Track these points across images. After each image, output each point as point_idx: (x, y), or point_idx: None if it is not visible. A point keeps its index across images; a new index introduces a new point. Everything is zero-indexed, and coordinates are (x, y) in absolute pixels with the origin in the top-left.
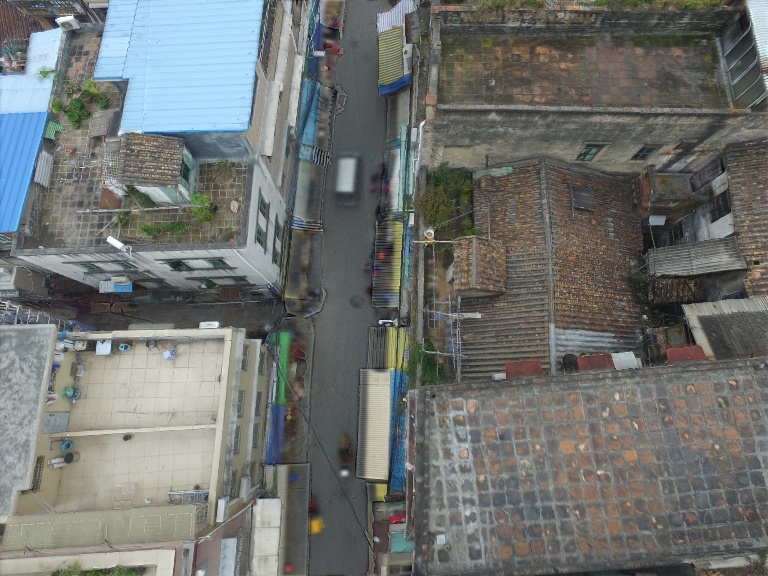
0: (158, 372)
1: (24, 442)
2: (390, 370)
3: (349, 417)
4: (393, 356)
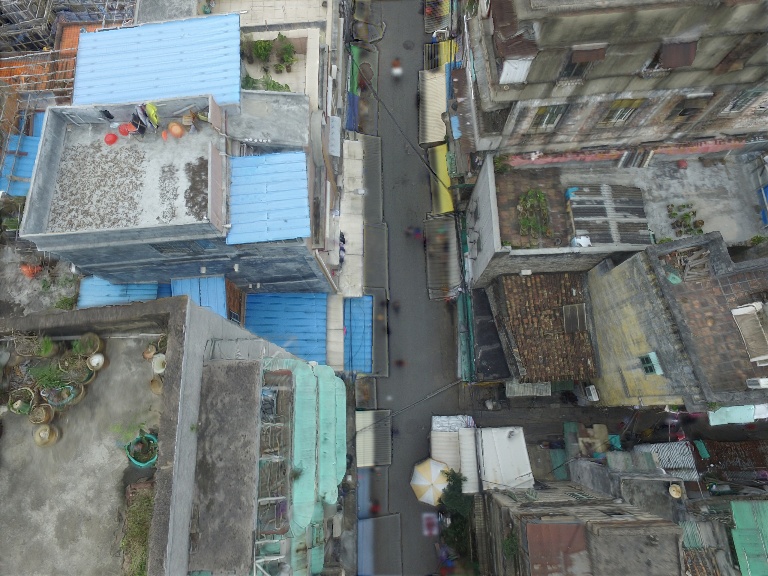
0: (273, 3)
1: (187, 10)
2: (445, 64)
3: (406, 128)
4: (445, 61)
